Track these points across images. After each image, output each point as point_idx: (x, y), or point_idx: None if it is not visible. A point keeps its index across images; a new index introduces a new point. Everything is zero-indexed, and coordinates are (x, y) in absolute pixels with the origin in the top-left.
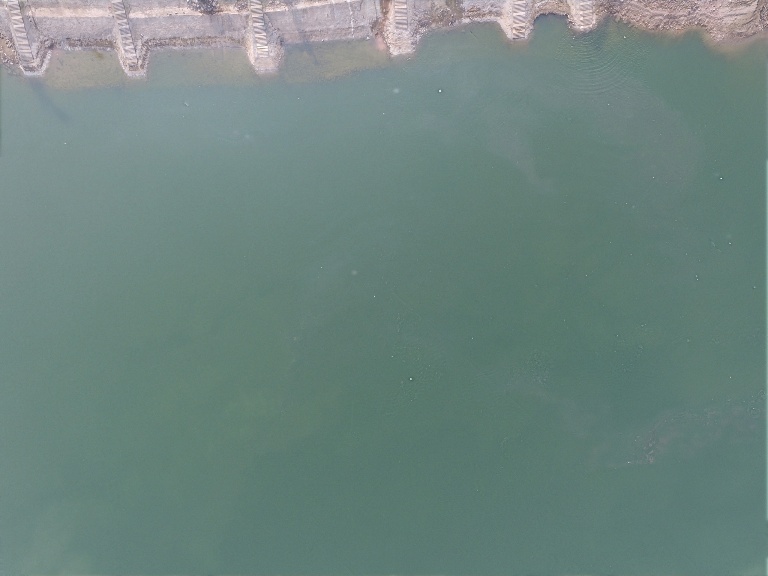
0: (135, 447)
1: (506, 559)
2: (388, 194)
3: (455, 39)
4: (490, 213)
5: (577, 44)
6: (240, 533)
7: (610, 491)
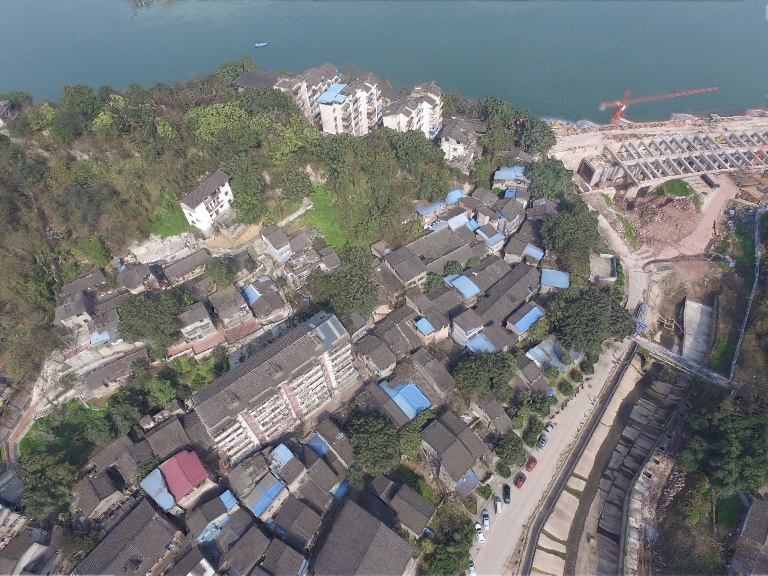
0: None
1: None
2: (660, 78)
3: (651, 120)
4: (607, 75)
5: (584, 118)
6: None
7: None
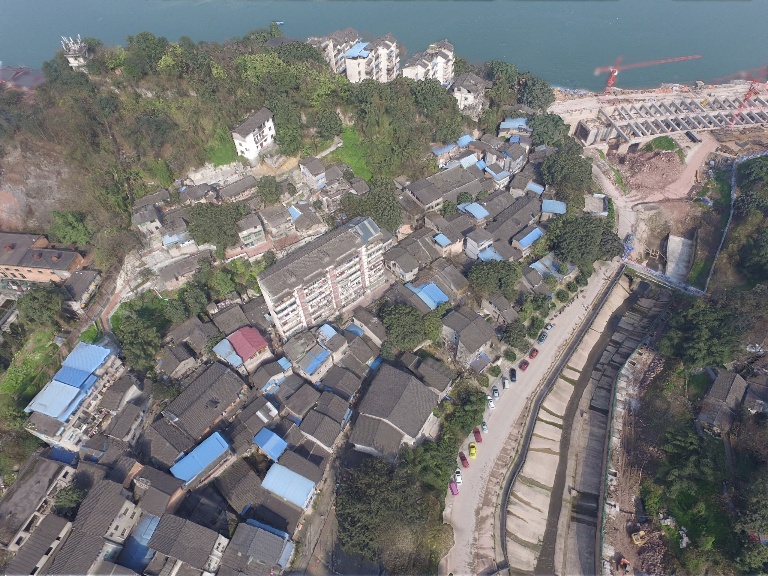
0: (723, 8)
1: None
2: None
3: (642, 89)
4: (602, 50)
5: (581, 87)
6: None
7: (531, 2)
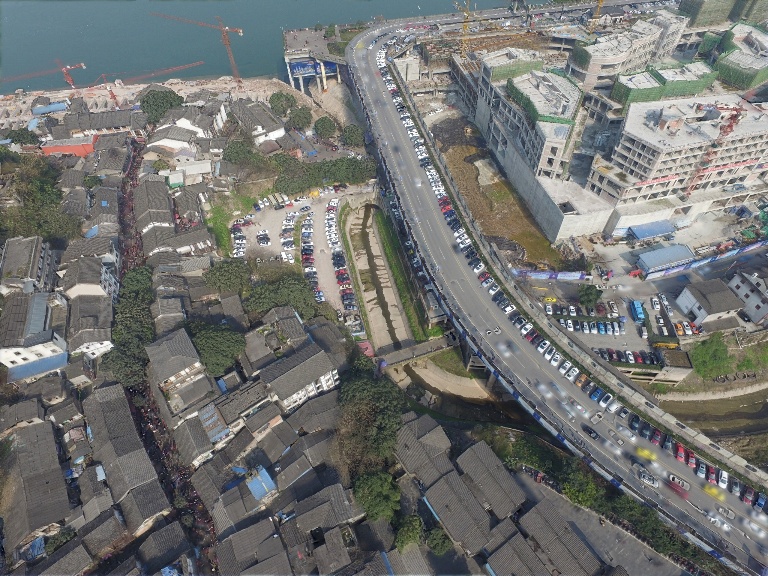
0: None
1: (75, 0)
2: None
3: None
4: (29, 59)
5: None
6: (175, 0)
7: None
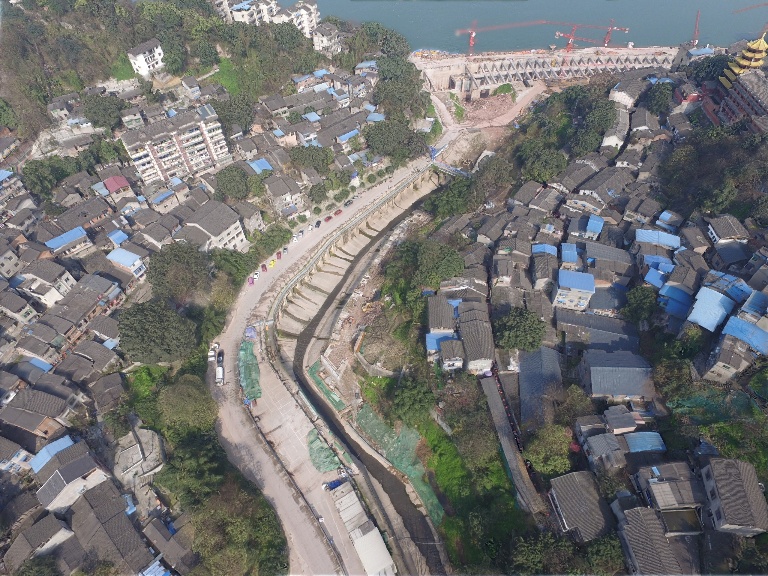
0: None
1: None
2: None
3: None
4: None
5: None
6: None
7: None
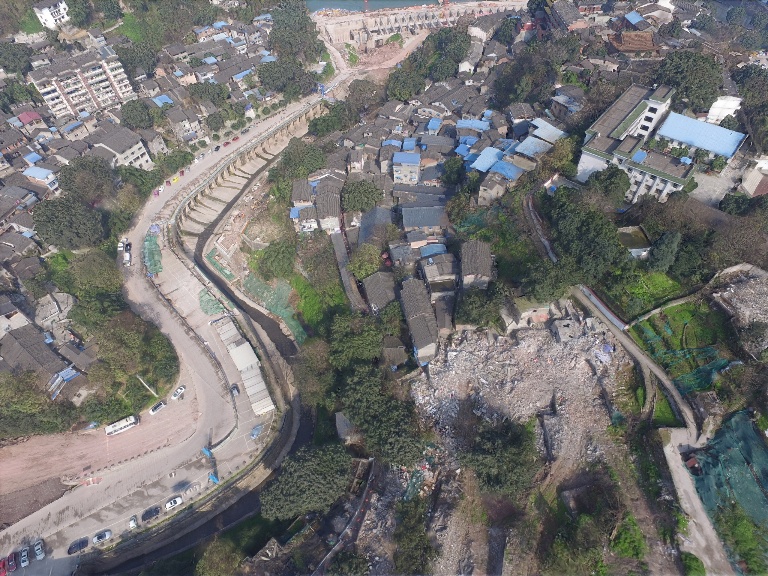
0: None
1: None
2: None
3: None
4: None
5: None
6: None
7: None
